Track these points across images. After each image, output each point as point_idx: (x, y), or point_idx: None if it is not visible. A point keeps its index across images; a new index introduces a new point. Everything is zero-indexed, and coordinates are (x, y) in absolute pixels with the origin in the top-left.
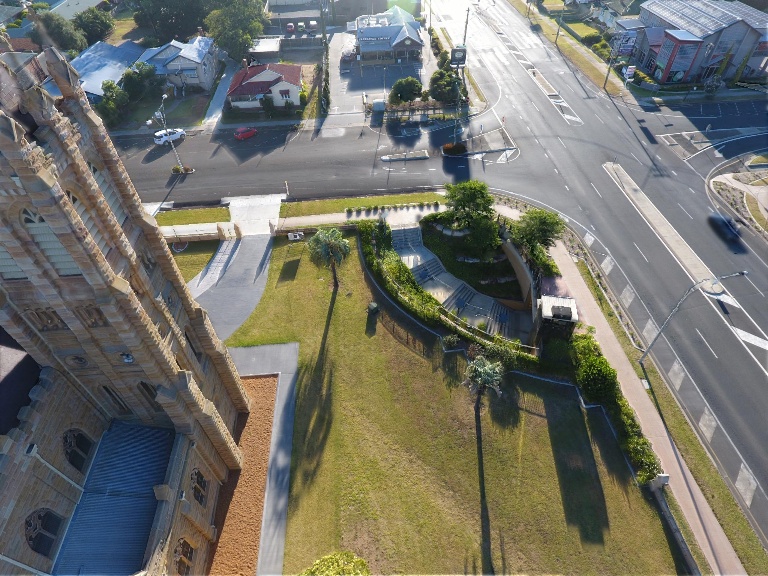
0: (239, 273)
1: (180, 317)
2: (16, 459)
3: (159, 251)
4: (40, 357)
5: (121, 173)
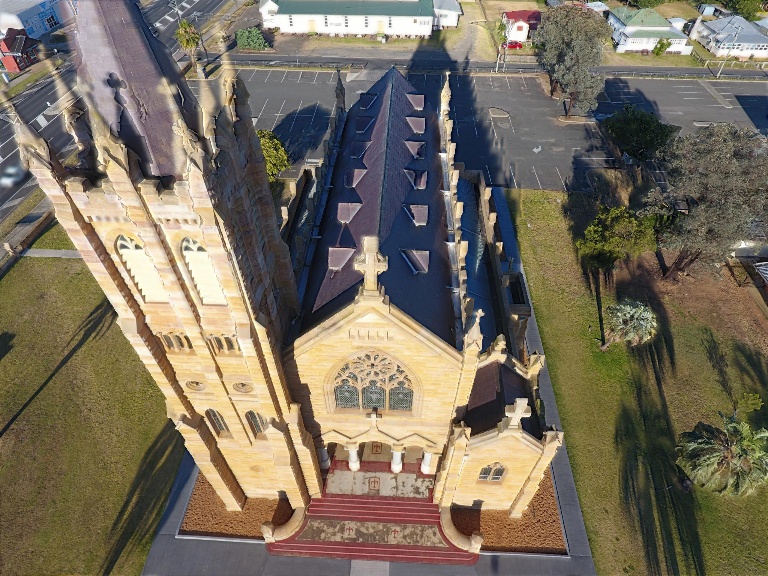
0: None
1: None
2: None
3: None
4: None
5: None
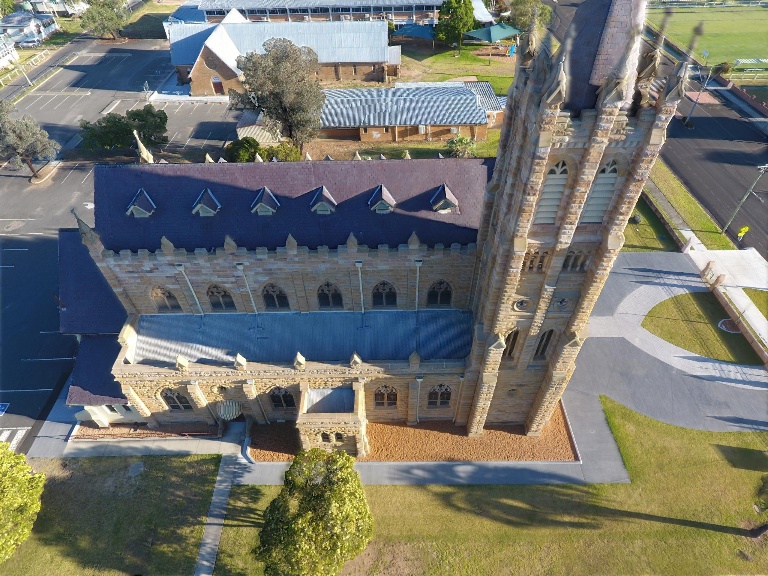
0: (716, 396)
1: (556, 320)
2: (410, 256)
3: (595, 267)
4: (479, 236)
5: (630, 191)
